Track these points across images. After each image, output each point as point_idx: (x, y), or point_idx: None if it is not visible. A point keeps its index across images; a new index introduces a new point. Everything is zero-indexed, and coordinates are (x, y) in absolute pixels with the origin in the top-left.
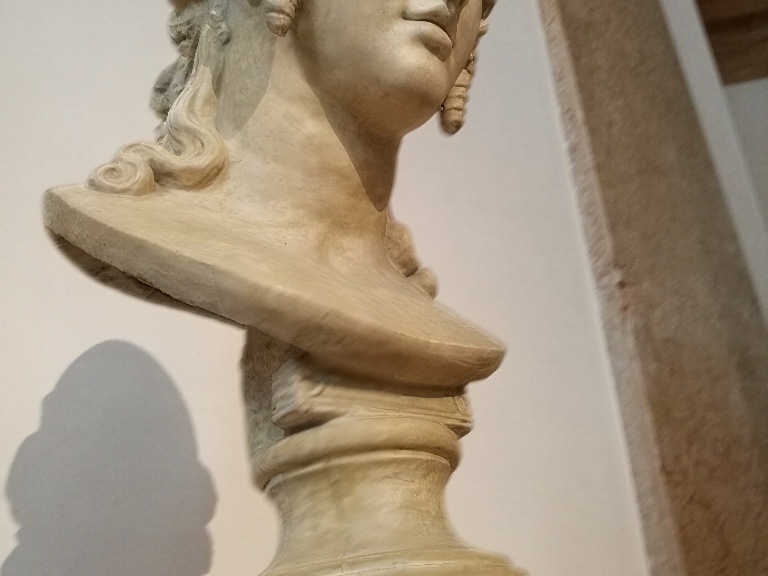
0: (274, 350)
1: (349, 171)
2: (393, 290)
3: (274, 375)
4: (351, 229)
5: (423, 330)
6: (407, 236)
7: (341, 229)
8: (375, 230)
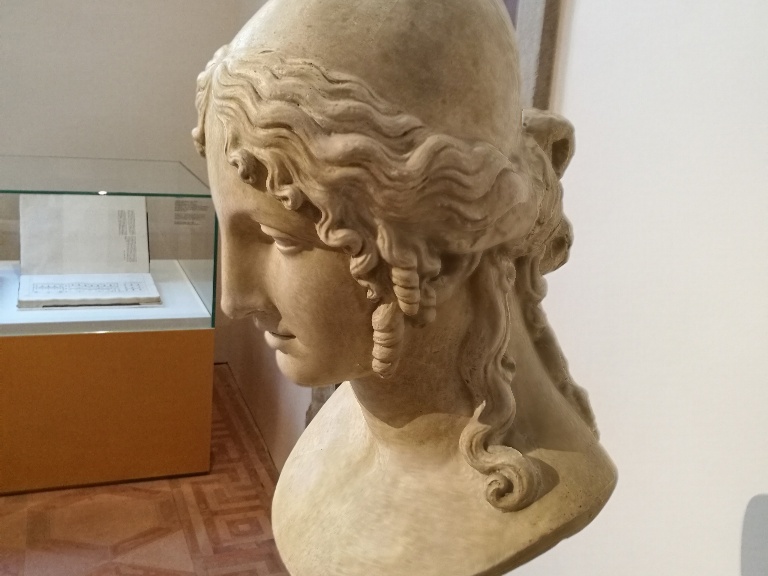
0: None
1: (357, 400)
2: (350, 509)
3: None
4: (381, 440)
5: (292, 555)
6: (461, 442)
7: (377, 438)
8: (403, 441)
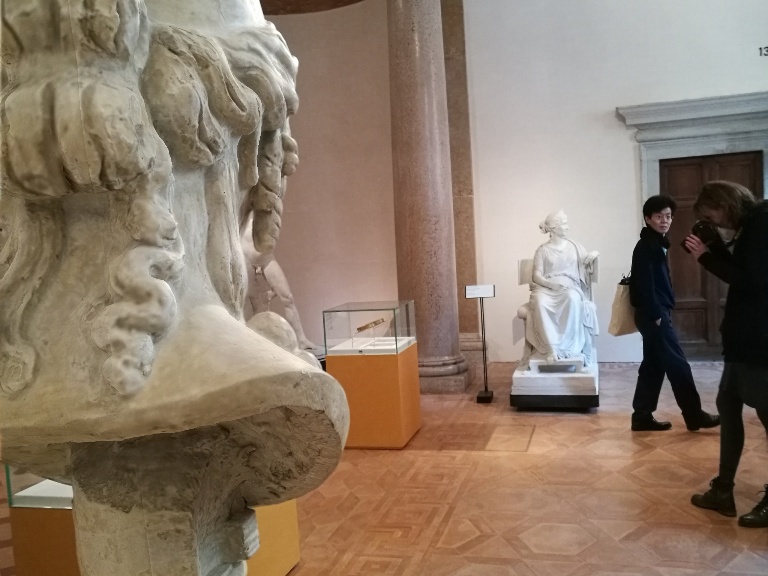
0: (218, 503)
1: None
2: None
3: (247, 525)
4: None
5: None
6: None
7: None
8: None
